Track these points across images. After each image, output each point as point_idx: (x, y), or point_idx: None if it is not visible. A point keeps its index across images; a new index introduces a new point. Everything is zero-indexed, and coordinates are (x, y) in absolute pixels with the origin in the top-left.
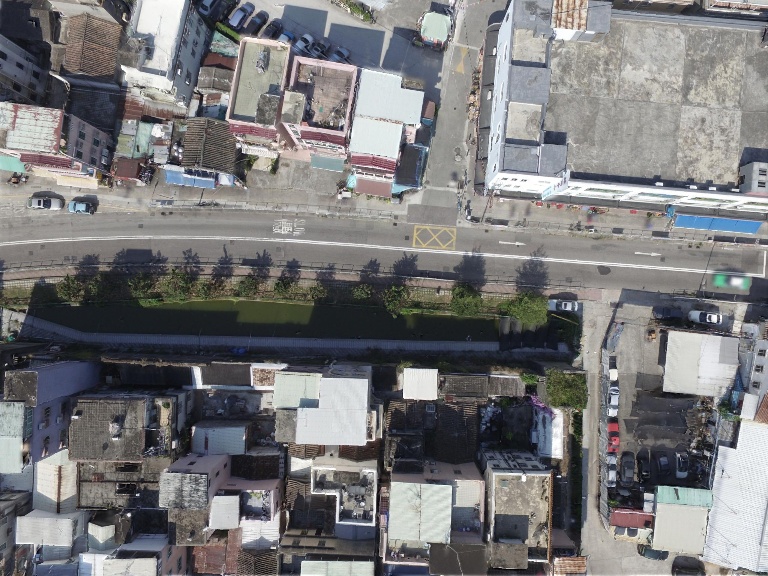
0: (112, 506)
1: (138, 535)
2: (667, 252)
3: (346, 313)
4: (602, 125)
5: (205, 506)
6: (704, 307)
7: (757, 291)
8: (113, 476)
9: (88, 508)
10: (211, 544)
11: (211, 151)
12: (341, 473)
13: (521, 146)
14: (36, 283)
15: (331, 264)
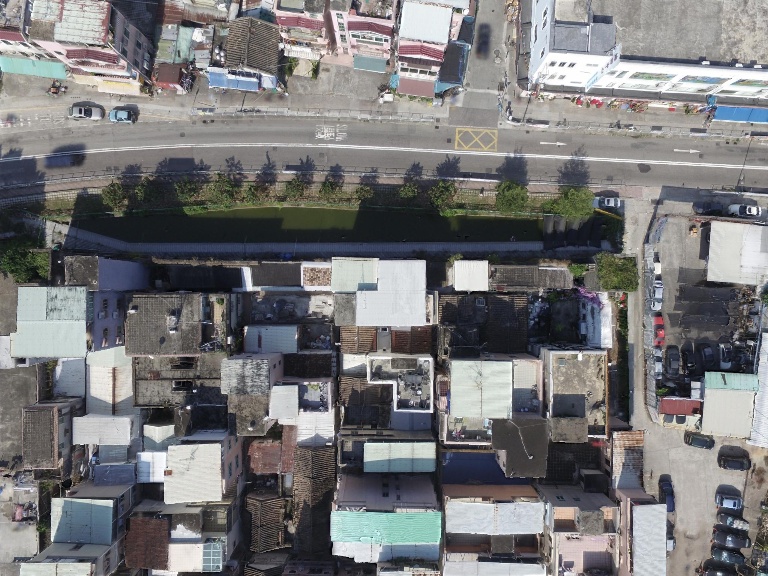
0: (169, 403)
1: (196, 431)
2: (705, 149)
3: (390, 217)
4: (647, 8)
5: (267, 390)
6: (743, 202)
7: None
8: (169, 374)
9: (145, 406)
10: (266, 444)
11: (255, 51)
12: (398, 360)
13: (571, 26)
14: (79, 194)
15: (374, 168)
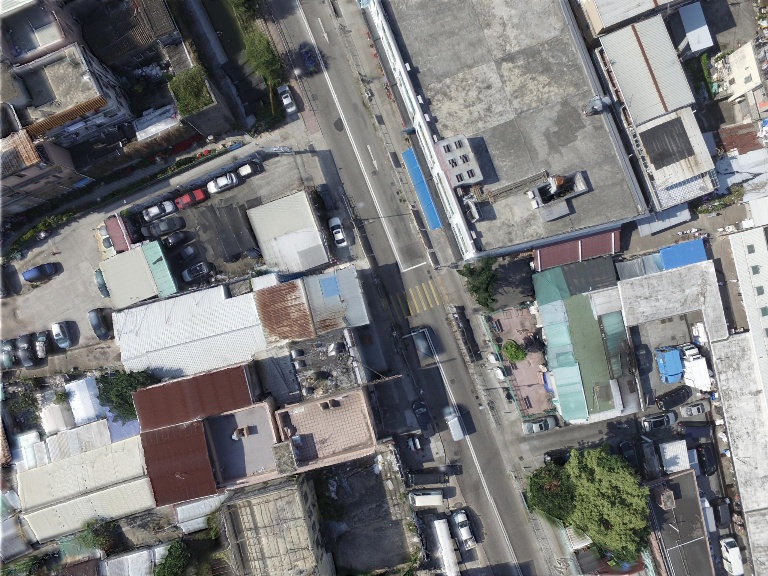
0: None
1: None
2: (383, 174)
3: None
4: None
5: None
6: (348, 230)
7: (386, 272)
8: None
9: None
10: None
11: None
12: None
13: None
14: None
15: None
